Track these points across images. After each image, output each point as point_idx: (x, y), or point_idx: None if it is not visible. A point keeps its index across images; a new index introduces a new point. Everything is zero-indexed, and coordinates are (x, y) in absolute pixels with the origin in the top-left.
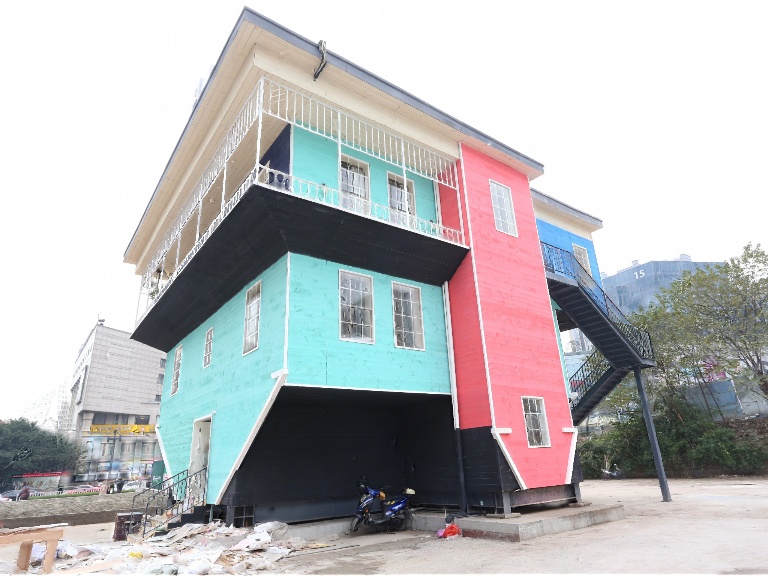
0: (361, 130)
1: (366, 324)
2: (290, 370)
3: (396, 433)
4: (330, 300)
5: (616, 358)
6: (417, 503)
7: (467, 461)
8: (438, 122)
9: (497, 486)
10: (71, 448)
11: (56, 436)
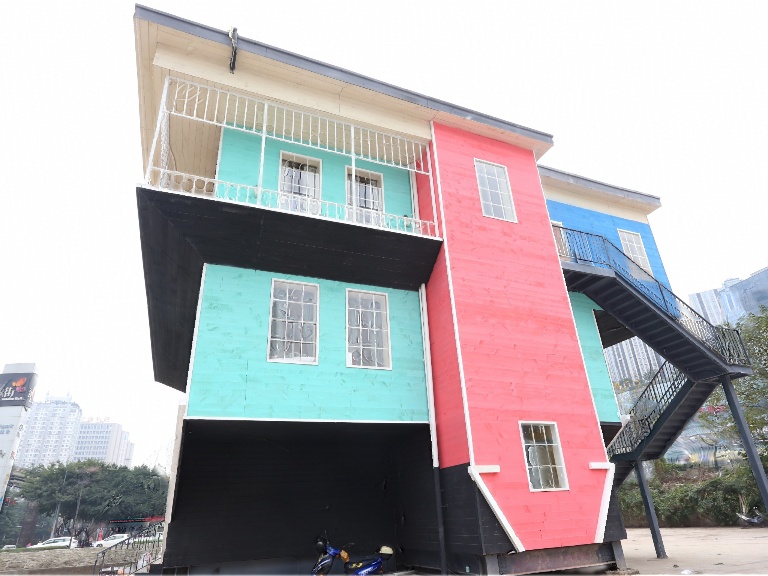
0: (295, 120)
1: (307, 341)
2: (193, 400)
3: (385, 474)
4: (257, 315)
5: (692, 367)
6: (410, 564)
7: (448, 511)
8: (395, 100)
9: (478, 546)
10: (159, 494)
11: (143, 482)
